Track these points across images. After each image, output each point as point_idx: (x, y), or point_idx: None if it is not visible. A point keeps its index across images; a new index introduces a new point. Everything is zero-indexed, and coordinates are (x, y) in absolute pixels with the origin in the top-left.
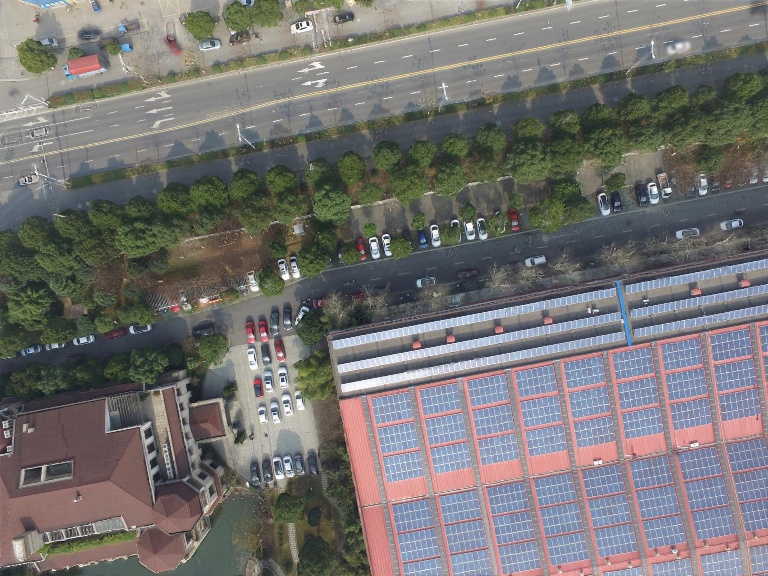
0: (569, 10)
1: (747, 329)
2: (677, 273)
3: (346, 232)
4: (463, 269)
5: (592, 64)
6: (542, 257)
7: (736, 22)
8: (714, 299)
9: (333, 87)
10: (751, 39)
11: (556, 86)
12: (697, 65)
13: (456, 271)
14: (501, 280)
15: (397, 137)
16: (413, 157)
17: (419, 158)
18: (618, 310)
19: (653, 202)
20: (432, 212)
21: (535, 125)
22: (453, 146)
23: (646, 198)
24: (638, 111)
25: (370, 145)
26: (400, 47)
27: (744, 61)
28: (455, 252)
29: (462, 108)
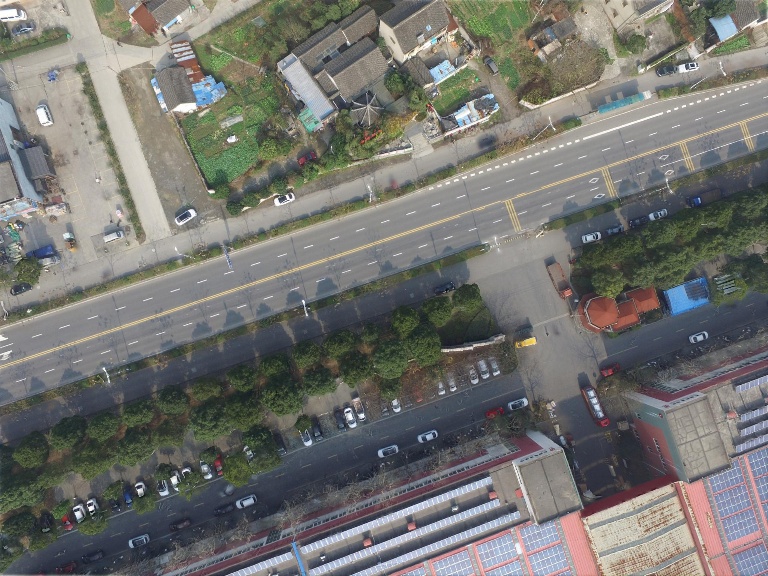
0: (248, 253)
1: (421, 568)
2: (349, 525)
3: (50, 503)
4: (175, 521)
5: (277, 301)
6: (250, 499)
7: (406, 245)
8: (386, 545)
9: (19, 358)
10: (422, 259)
11: (243, 329)
12: (375, 290)
13: (169, 524)
14: (177, 563)
15: (92, 399)
16: (90, 437)
17: (96, 437)
18: (298, 570)
19: (351, 426)
20: (137, 468)
21: (203, 393)
22: (128, 422)
23: (343, 425)
24: (302, 365)
25: (66, 410)
26: (84, 309)
27: (419, 280)
28: (166, 505)
29: (152, 363)
